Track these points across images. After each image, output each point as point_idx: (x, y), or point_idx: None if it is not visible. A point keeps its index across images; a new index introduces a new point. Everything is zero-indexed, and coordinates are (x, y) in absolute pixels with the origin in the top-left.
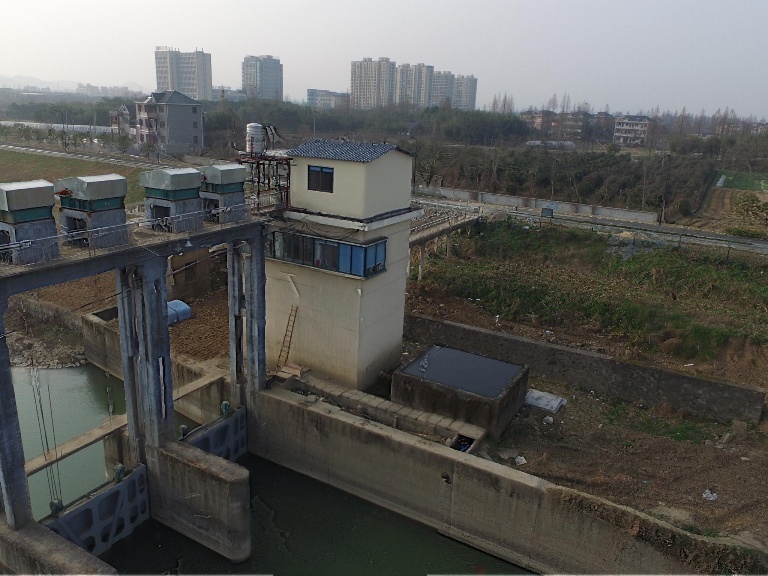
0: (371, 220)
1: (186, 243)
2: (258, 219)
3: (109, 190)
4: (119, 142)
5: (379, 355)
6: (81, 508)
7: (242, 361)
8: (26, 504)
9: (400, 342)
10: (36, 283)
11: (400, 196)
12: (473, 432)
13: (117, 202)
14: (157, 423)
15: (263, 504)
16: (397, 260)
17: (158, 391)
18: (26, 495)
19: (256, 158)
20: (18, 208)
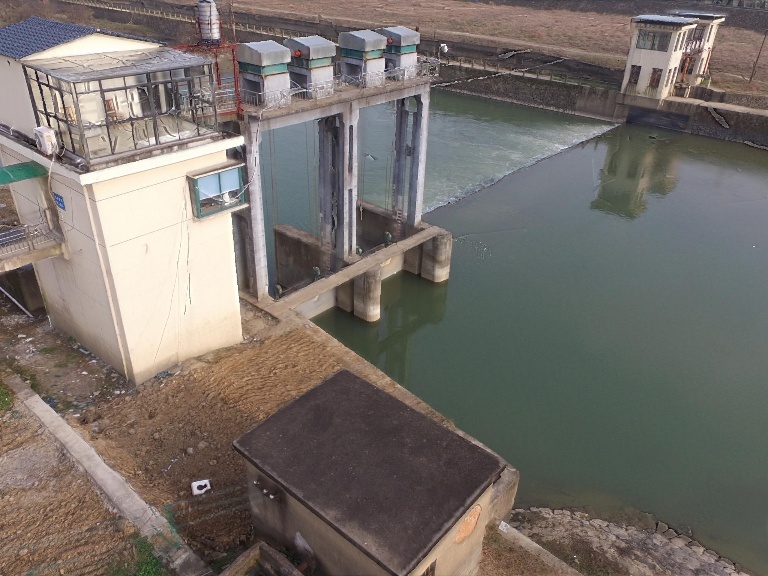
0: None
1: None
2: None
3: None
4: None
5: None
6: None
7: None
8: None
9: None
10: None
11: None
12: None
13: None
14: None
15: None
16: None
17: None
18: None
19: None
20: None
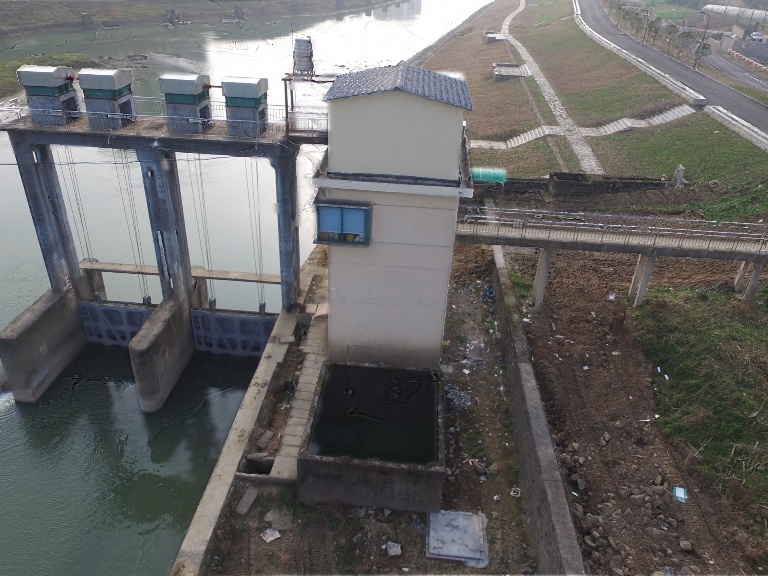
0: (346, 177)
1: (155, 142)
2: (258, 140)
3: (98, 83)
4: (679, 39)
5: (379, 343)
6: (113, 307)
7: (296, 277)
8: (58, 280)
9: (434, 348)
10: (47, 140)
11: (429, 160)
12: (282, 468)
13: (109, 94)
14: (161, 280)
15: (216, 394)
16: (420, 243)
17: (159, 256)
18: (57, 275)
19: (296, 75)
20: (27, 84)
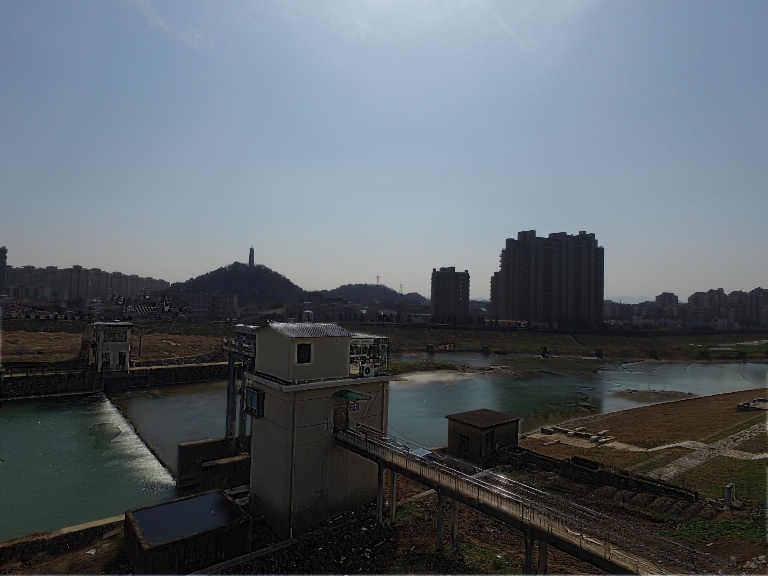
0: None
1: None
2: None
3: None
4: None
5: None
6: None
7: None
8: None
9: None
10: None
11: None
12: None
13: None
14: None
15: None
16: None
17: None
18: None
19: None
20: None
